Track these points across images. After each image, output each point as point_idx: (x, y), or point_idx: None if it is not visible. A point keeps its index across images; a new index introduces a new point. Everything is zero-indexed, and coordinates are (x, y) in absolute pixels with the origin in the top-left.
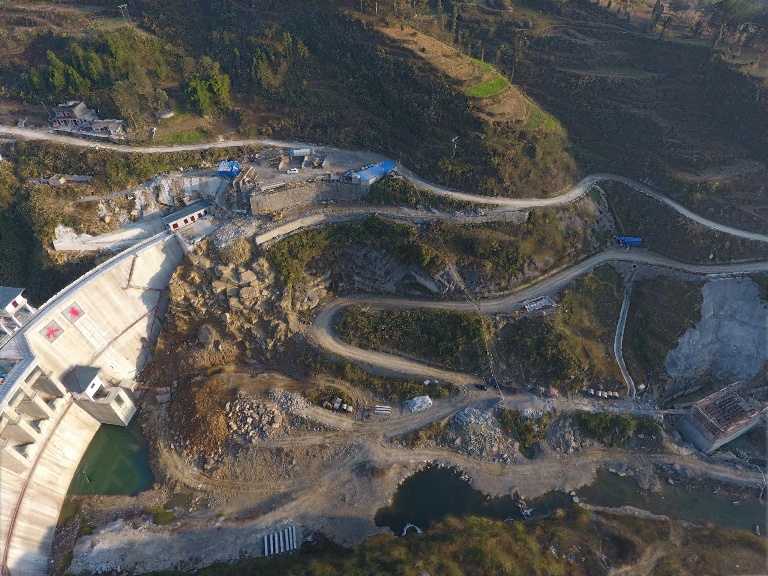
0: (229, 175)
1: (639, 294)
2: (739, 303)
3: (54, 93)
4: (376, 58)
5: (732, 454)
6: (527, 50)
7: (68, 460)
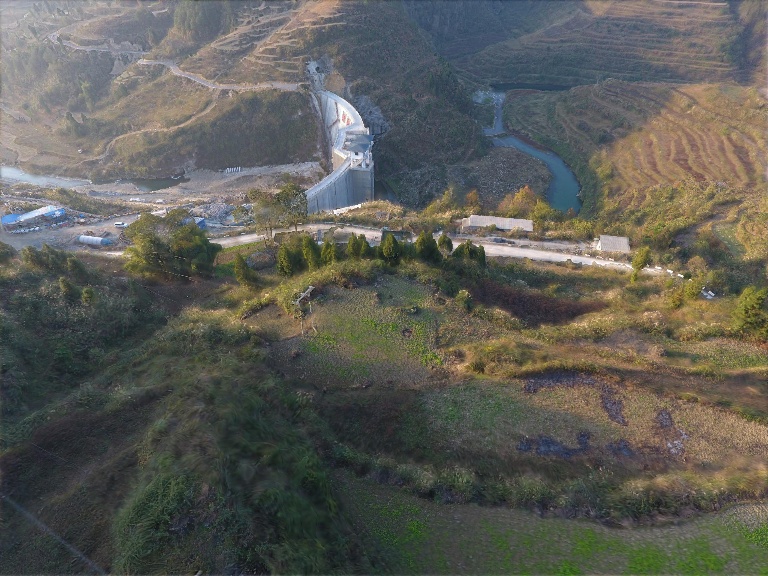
0: None
1: None
2: None
3: None
4: None
5: None
6: None
7: None
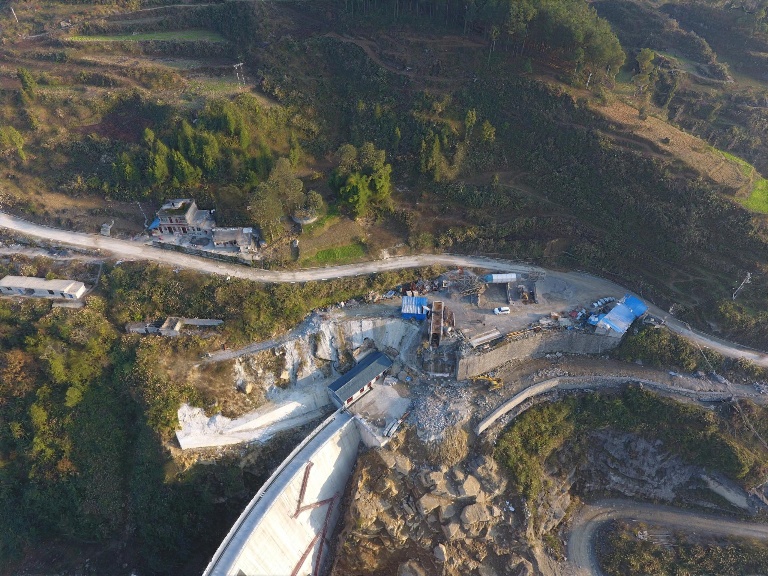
0: (416, 317)
1: None
2: None
3: (151, 186)
4: (597, 148)
5: None
6: (764, 134)
7: None
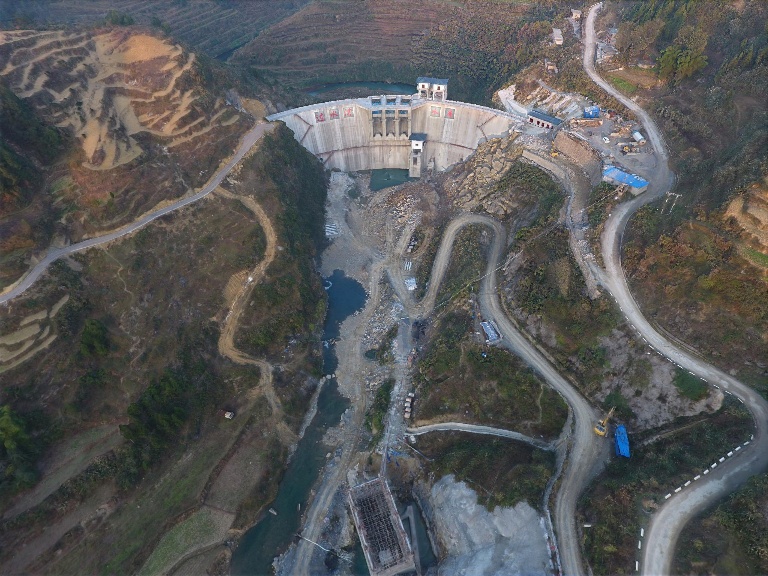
0: None
1: (531, 450)
2: (518, 573)
3: None
4: None
5: (347, 541)
6: None
7: (388, 162)
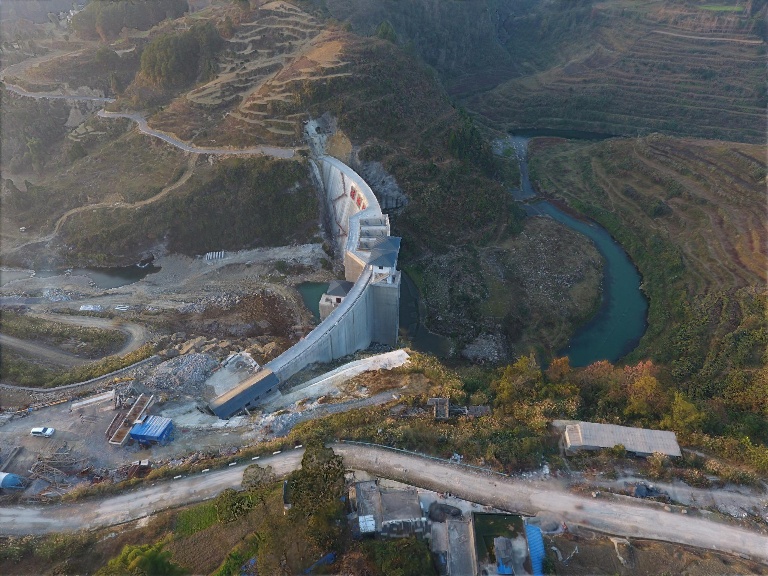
0: None
1: None
2: None
3: None
4: None
5: None
6: None
7: None
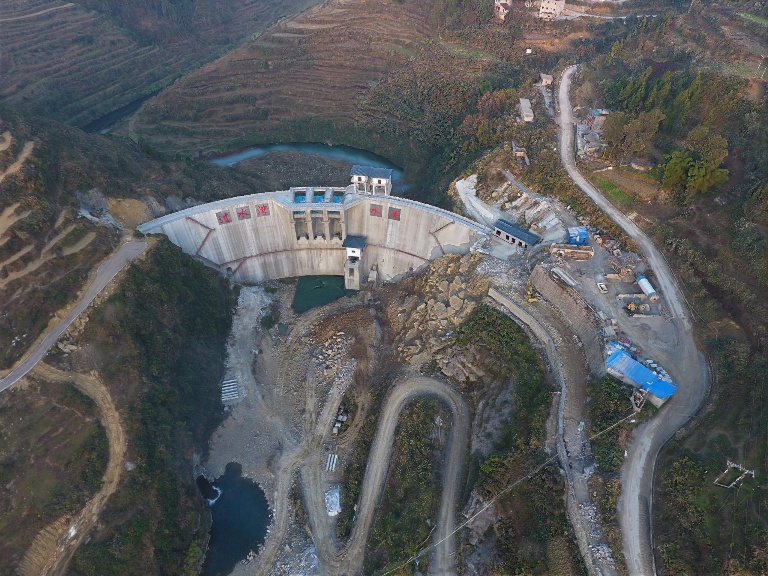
0: None
1: None
2: None
3: None
4: None
5: None
6: None
7: (318, 267)
